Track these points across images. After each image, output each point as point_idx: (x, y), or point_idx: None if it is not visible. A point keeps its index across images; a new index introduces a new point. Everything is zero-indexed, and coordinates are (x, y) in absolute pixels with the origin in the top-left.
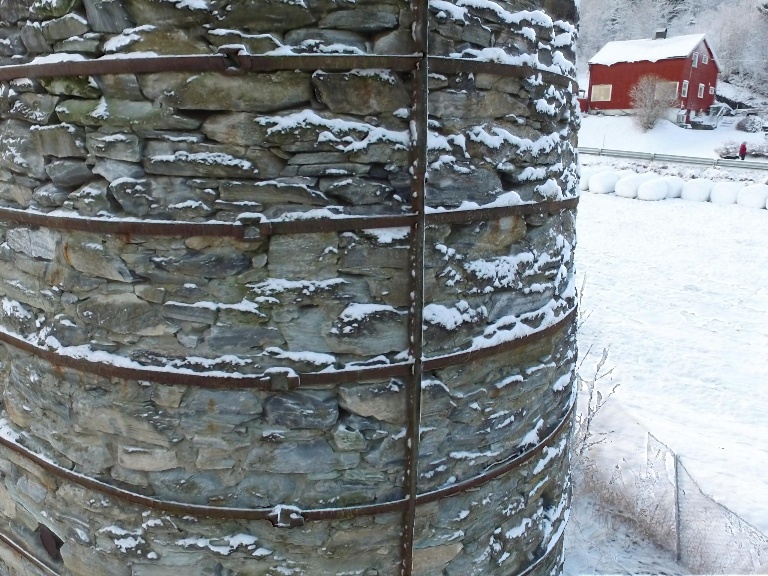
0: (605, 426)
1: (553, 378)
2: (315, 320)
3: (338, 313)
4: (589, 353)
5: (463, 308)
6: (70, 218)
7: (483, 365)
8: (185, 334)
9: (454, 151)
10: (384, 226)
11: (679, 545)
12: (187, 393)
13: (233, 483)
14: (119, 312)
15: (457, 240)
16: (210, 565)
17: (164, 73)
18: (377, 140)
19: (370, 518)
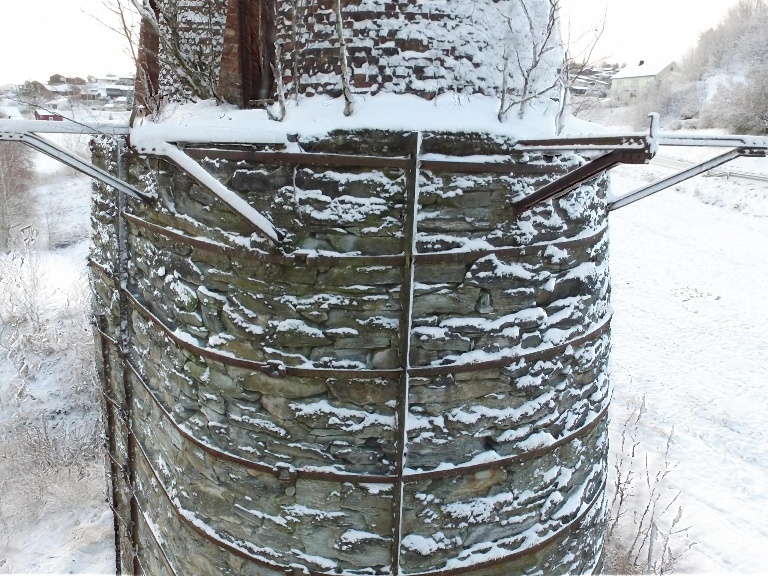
0: (722, 554)
1: None
2: (324, 536)
3: (340, 535)
4: (739, 457)
5: (439, 538)
6: (188, 435)
7: None
8: (245, 526)
9: (434, 427)
10: (373, 482)
11: None
12: (245, 563)
13: None
14: (211, 500)
15: (437, 488)
16: None
17: (238, 367)
18: (370, 424)
19: None
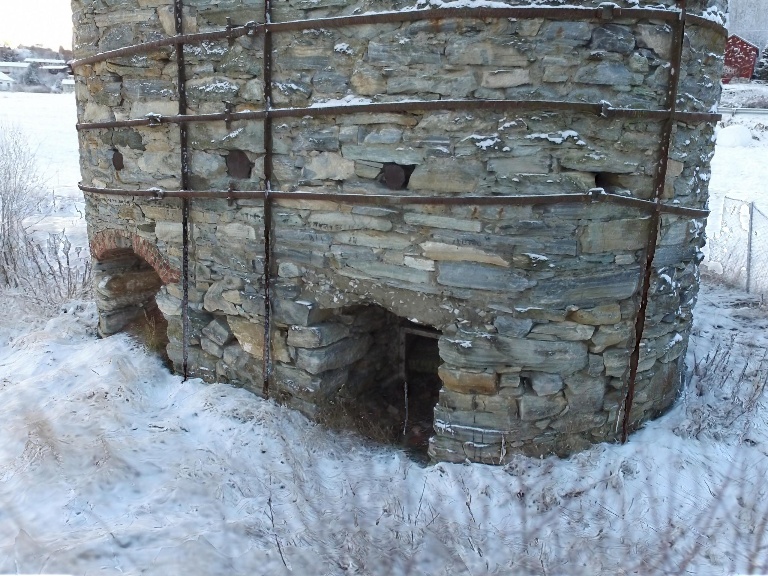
0: None
1: None
2: None
3: None
4: None
5: None
6: None
7: (702, 37)
8: None
9: None
10: None
11: (749, 280)
12: (543, 25)
13: (565, 93)
14: None
15: None
16: (545, 154)
17: None
18: None
19: (645, 125)
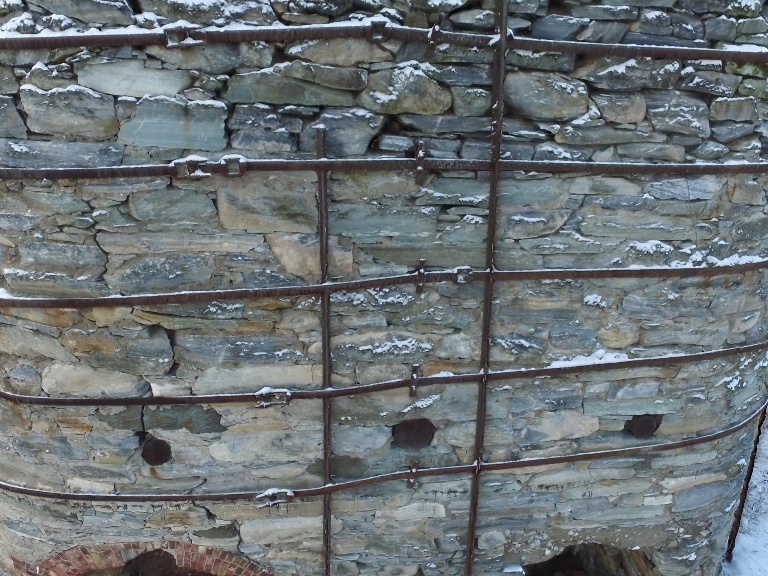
0: None
1: None
2: None
3: None
4: None
5: None
6: (746, 165)
7: None
8: None
9: None
10: None
11: None
12: None
13: None
14: (757, 226)
15: None
16: (758, 378)
17: None
18: None
19: None
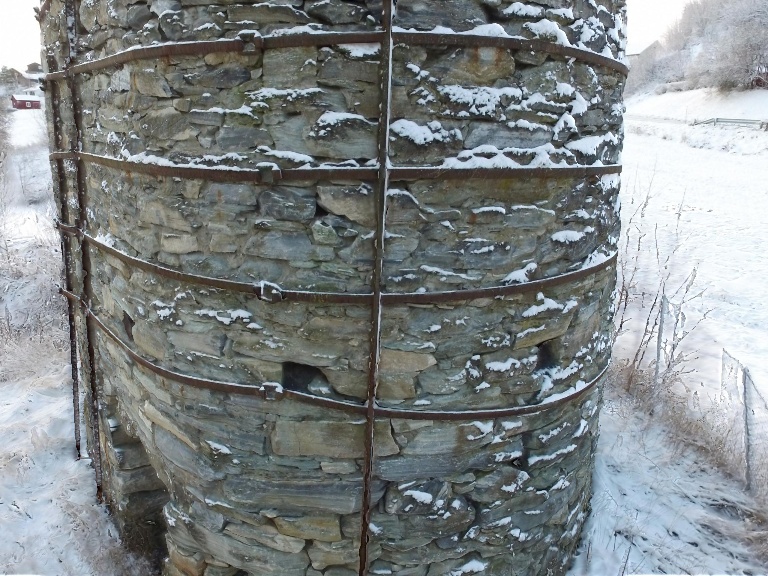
0: None
1: (552, 227)
2: (297, 125)
3: (316, 119)
4: (740, 323)
5: (435, 127)
6: (136, 50)
7: (459, 189)
8: (203, 137)
9: None
10: (356, 41)
11: (748, 474)
12: (204, 186)
13: (236, 265)
14: (163, 122)
15: (433, 64)
16: (218, 334)
17: None
18: None
19: (342, 309)
